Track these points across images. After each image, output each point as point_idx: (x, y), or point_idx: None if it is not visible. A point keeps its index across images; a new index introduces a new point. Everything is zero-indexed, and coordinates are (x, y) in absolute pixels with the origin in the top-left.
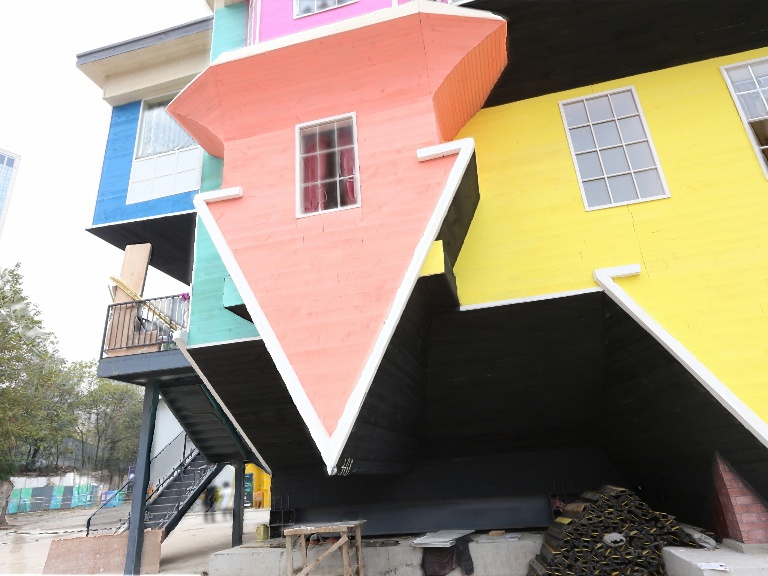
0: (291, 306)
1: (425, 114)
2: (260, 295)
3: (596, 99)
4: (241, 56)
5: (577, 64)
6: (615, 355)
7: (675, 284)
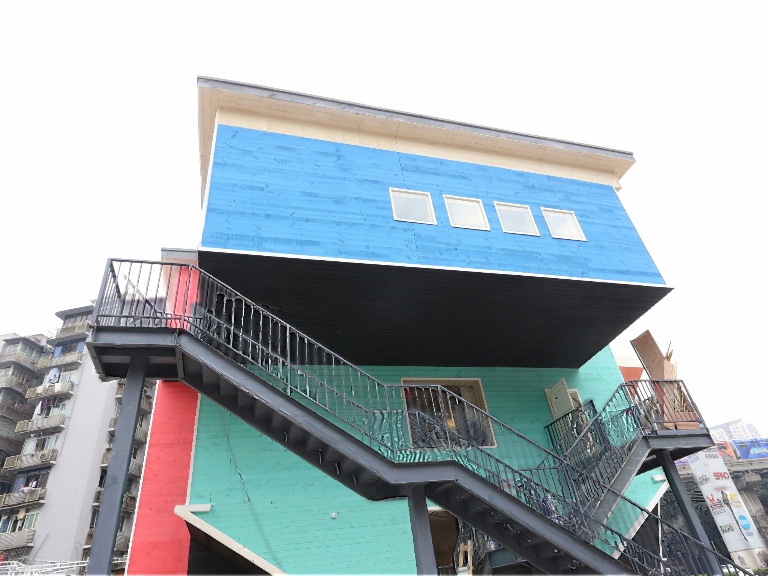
0: None
1: None
2: None
3: None
4: None
5: None
6: None
7: None
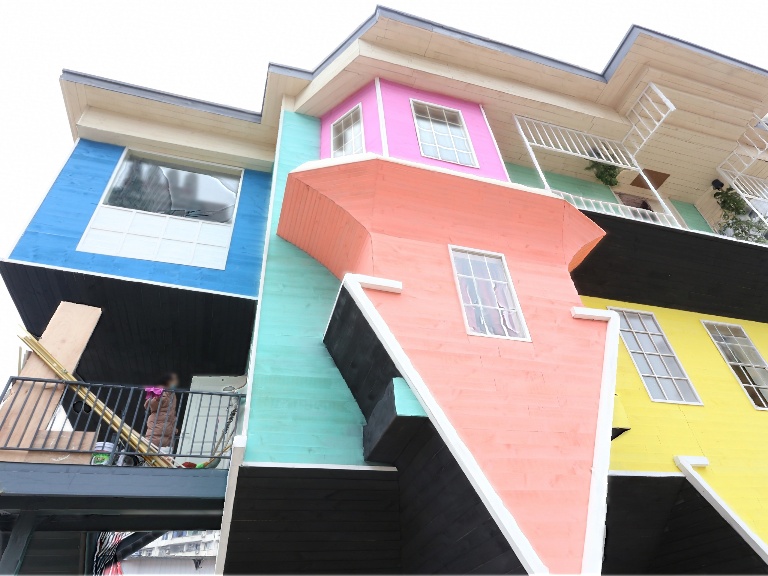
0: (483, 431)
1: (565, 279)
2: (444, 410)
3: (631, 313)
4: (410, 164)
5: (622, 283)
6: (673, 545)
7: (732, 481)
